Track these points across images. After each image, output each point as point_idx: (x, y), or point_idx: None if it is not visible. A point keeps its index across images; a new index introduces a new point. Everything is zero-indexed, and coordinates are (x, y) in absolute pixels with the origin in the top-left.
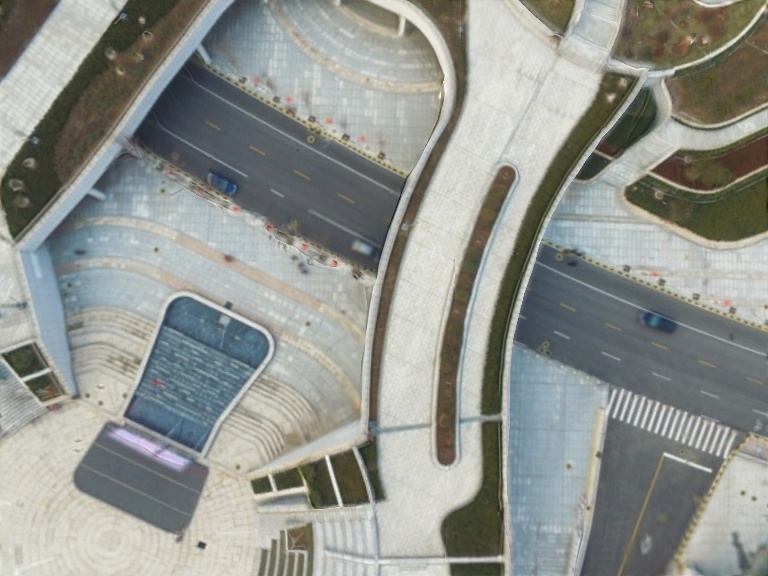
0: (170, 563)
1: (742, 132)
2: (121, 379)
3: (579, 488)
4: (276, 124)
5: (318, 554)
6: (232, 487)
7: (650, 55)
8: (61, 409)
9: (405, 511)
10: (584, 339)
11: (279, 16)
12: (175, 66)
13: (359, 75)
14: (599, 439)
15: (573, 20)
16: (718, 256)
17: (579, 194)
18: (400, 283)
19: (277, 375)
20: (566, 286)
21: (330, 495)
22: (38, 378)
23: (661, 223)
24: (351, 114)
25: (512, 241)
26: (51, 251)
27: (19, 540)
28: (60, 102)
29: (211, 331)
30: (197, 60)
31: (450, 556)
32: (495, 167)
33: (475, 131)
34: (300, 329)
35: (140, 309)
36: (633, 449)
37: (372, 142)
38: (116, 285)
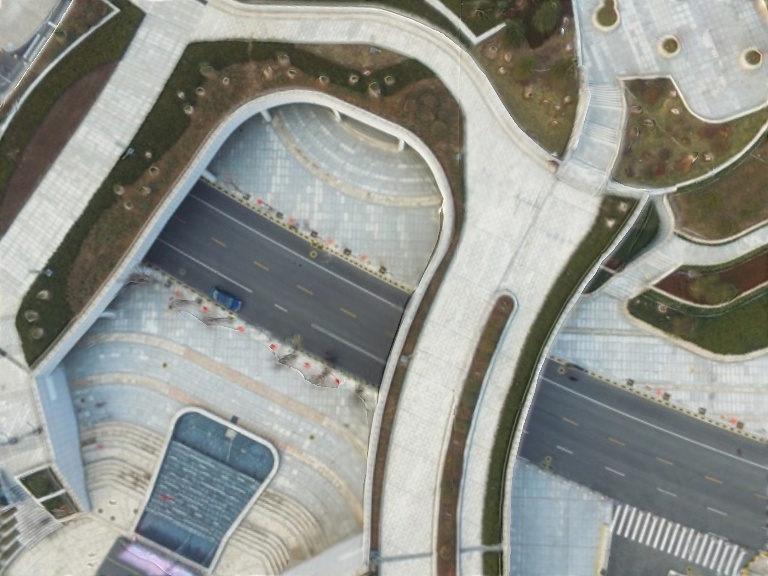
0: None
1: (748, 246)
2: (132, 495)
3: None
4: (279, 240)
5: None
6: None
7: (651, 174)
8: (75, 524)
9: None
10: (587, 454)
11: (281, 133)
12: (181, 195)
13: (360, 190)
14: (603, 556)
15: (571, 145)
16: (724, 369)
17: (581, 307)
18: (400, 413)
19: (282, 488)
20: (568, 400)
21: None
22: (53, 498)
23: (665, 337)
24: (352, 229)
25: (511, 370)
26: (65, 370)
27: None
28: (72, 235)
29: (218, 444)
30: (202, 184)
31: None
32: (494, 296)
33: (474, 259)
34: (304, 443)
35: (150, 424)
36: (638, 566)
37: (373, 256)
38: (127, 400)
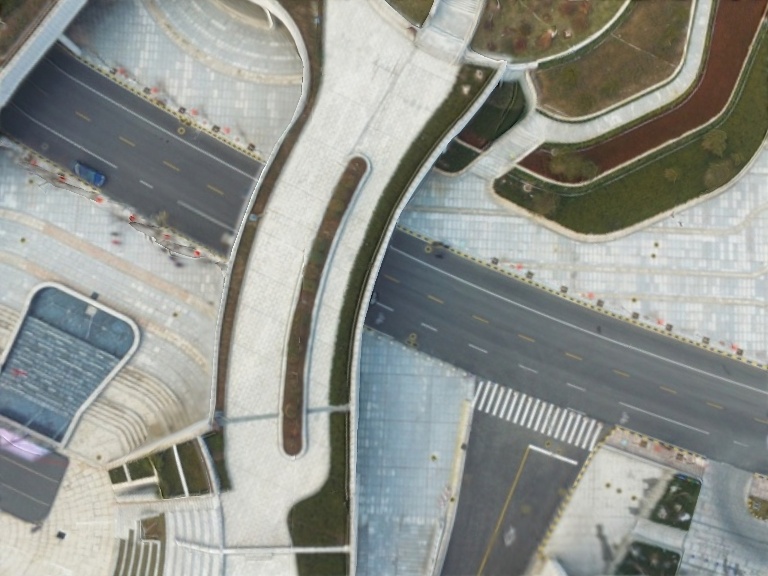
0: (29, 553)
1: (608, 125)
2: None
3: (443, 480)
4: (146, 115)
5: (170, 544)
6: (92, 477)
7: (512, 48)
8: None
9: (251, 501)
10: (451, 331)
11: (151, 7)
12: (33, 56)
13: (230, 67)
14: (464, 431)
15: (429, 12)
16: (587, 249)
17: (448, 186)
18: (249, 273)
19: (143, 366)
20: (434, 278)
21: (177, 485)
22: None
23: (529, 216)
24: (222, 106)
25: (362, 232)
26: None
27: None
28: None
29: (78, 322)
30: (61, 50)
31: (296, 546)
32: (347, 158)
33: (329, 122)
34: (167, 320)
35: (5, 299)
36: (498, 441)
37: (242, 134)
38: None
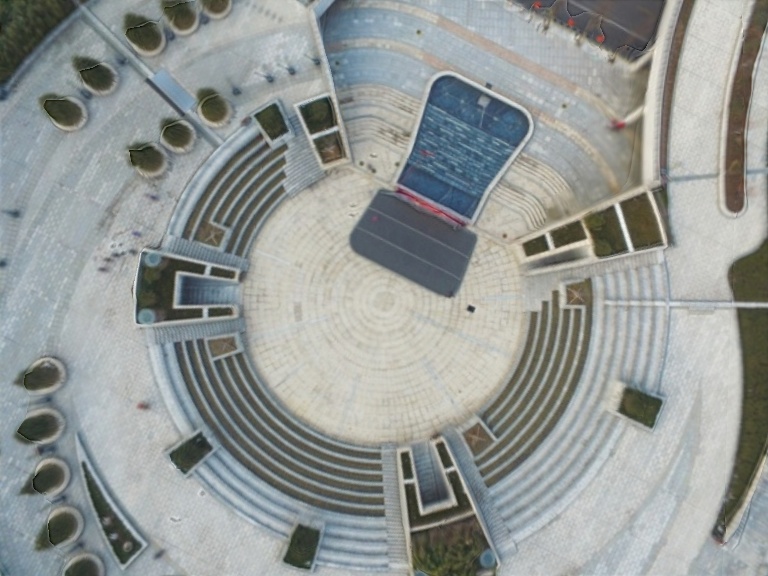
0: (441, 325)
1: None
2: (393, 148)
3: None
4: None
5: (598, 307)
6: (499, 254)
7: None
8: (337, 175)
9: (693, 257)
10: None
11: None
12: None
13: None
14: None
15: None
16: None
17: None
18: (688, 38)
19: (536, 154)
20: None
21: (619, 242)
22: (325, 136)
23: None
24: None
25: None
26: (326, 25)
27: (298, 298)
28: None
29: (471, 112)
30: None
31: (737, 301)
32: None
33: None
34: (557, 111)
35: (405, 87)
36: None
37: None
38: (381, 64)
